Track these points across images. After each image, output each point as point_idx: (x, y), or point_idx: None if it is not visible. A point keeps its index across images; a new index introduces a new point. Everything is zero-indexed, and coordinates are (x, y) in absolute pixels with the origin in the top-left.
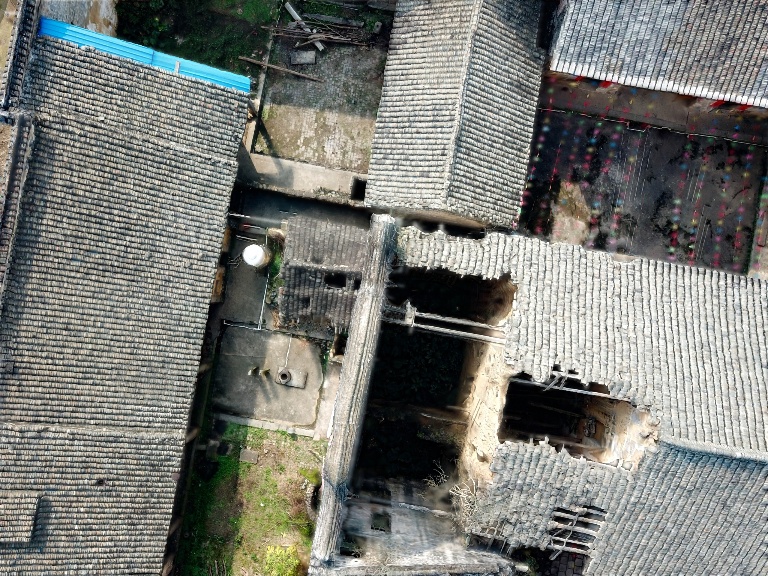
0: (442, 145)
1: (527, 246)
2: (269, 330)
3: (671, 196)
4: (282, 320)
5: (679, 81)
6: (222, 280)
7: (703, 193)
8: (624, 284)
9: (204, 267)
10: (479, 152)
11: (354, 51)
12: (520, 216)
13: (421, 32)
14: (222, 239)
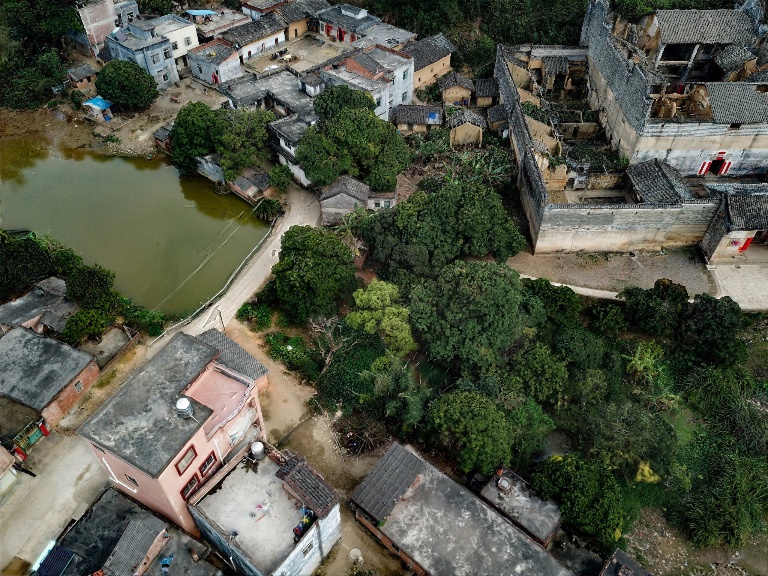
0: None
1: None
2: None
3: None
4: None
5: None
6: None
7: None
8: (764, 115)
9: None
10: None
11: None
12: None
13: None
14: None
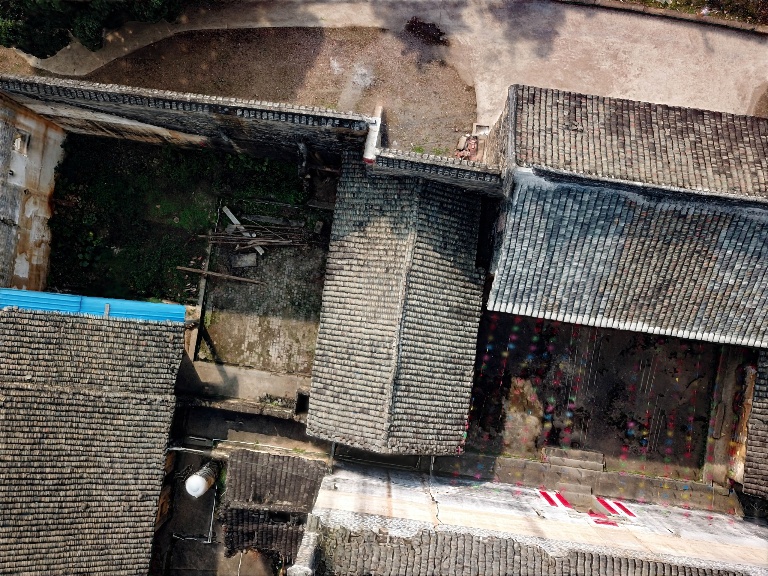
0: (381, 383)
1: (459, 545)
2: (219, 542)
3: (624, 388)
4: (227, 554)
5: (619, 318)
6: (168, 498)
7: (656, 383)
8: None
9: (144, 507)
10: (420, 386)
11: (296, 251)
12: (471, 413)
13: (357, 261)
14: (162, 476)
